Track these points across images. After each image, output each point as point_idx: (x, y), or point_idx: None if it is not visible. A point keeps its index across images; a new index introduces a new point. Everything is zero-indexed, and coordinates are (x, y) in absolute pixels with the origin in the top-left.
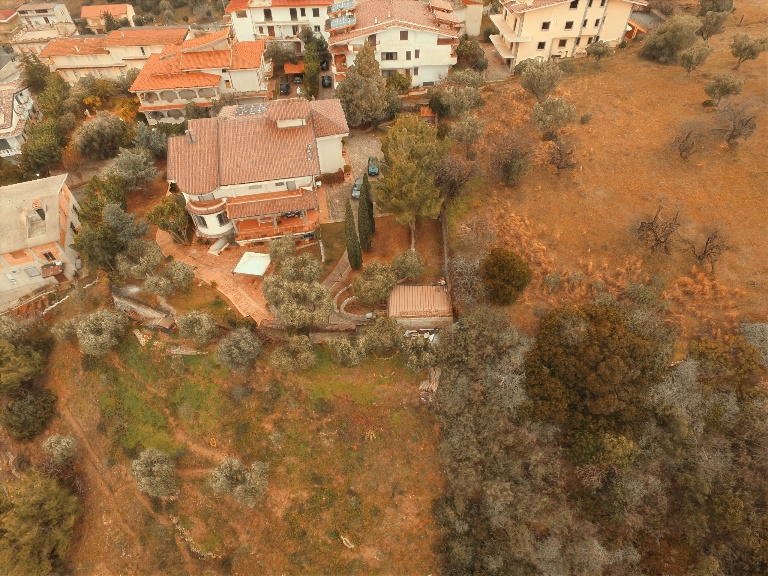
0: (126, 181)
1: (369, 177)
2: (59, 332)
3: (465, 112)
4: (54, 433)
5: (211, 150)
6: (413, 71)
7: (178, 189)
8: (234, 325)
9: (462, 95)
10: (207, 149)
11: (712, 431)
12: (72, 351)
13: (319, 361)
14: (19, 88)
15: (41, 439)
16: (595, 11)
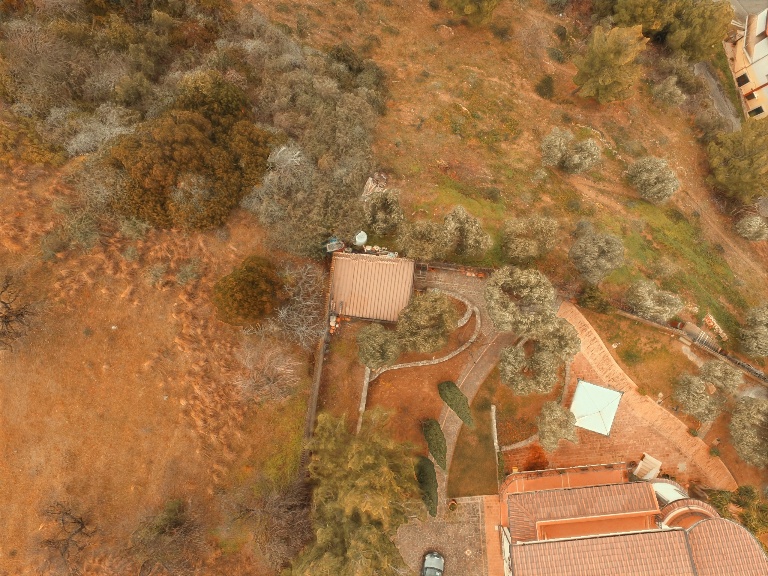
0: None
1: None
2: None
3: None
4: (766, 258)
5: None
6: None
7: None
8: (607, 303)
9: None
10: None
11: (92, 104)
12: None
13: (498, 245)
14: None
15: None
16: None
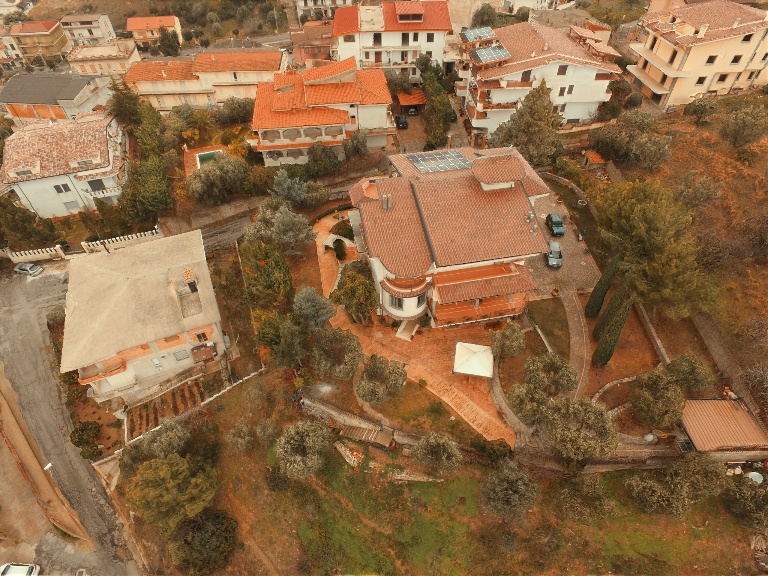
0: (283, 245)
1: (553, 238)
2: (239, 442)
3: (692, 171)
4: (239, 570)
5: (411, 219)
6: (560, 107)
7: (346, 255)
8: (480, 448)
9: (662, 145)
10: (407, 217)
11: None
12: (247, 461)
13: None
14: (106, 118)
15: (220, 575)
16: (766, 44)
